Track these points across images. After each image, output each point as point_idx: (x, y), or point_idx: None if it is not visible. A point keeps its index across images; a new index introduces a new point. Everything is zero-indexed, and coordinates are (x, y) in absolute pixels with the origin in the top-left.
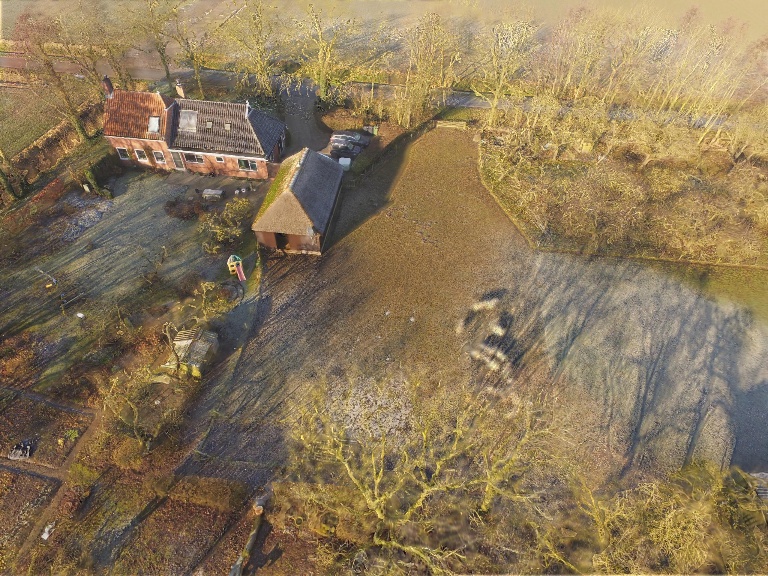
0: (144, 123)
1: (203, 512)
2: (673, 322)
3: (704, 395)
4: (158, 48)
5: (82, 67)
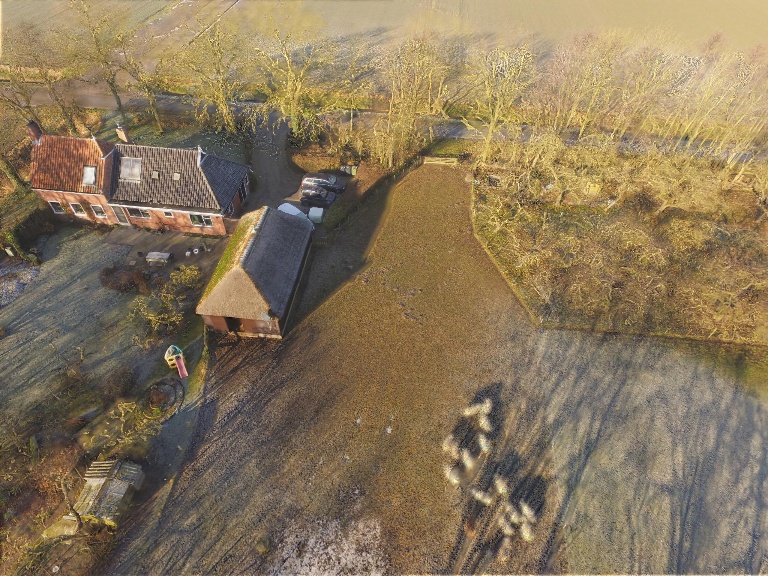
0: (78, 174)
1: None
2: (708, 428)
3: (754, 540)
4: (106, 78)
5: (12, 104)
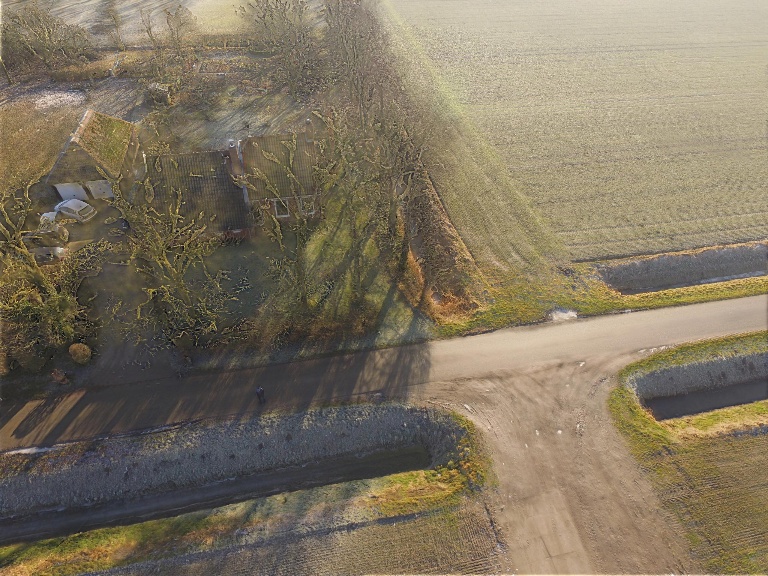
0: None
1: (136, 73)
2: None
3: None
4: None
5: None
